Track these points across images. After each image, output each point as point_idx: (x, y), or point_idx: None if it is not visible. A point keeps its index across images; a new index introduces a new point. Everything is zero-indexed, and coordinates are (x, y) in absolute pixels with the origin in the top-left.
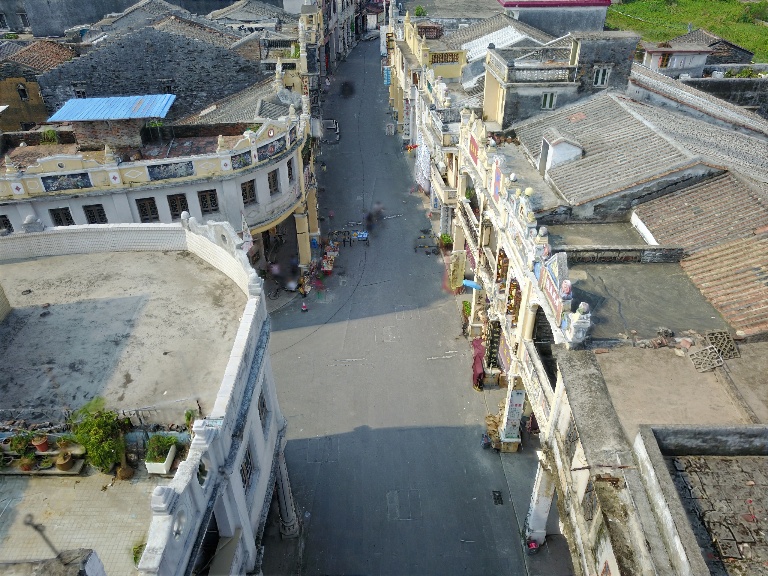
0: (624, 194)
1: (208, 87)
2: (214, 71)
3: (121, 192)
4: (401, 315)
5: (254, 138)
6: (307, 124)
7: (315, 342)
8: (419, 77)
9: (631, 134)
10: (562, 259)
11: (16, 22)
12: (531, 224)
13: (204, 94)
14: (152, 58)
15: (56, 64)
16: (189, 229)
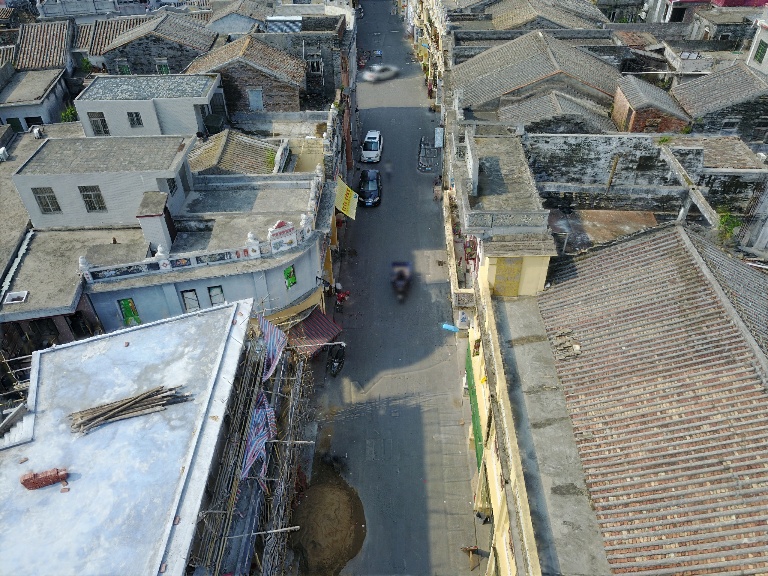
0: (481, 3)
1: None
2: None
3: None
4: (398, 80)
5: None
6: None
7: (359, 87)
8: None
9: None
10: (446, 10)
11: None
12: (441, 7)
13: None
14: None
15: None
16: (327, 5)
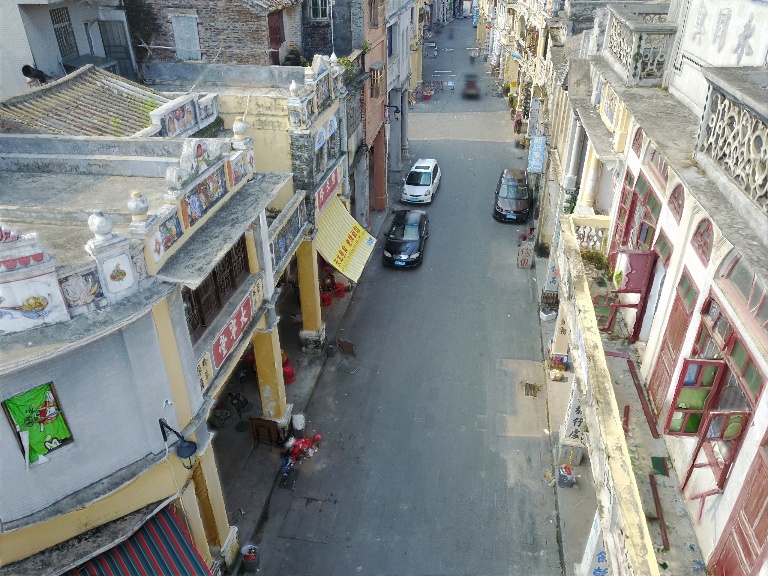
0: None
1: None
2: None
3: None
4: (473, 113)
5: None
6: None
7: (418, 117)
8: None
9: None
10: None
11: None
12: None
13: None
14: None
15: None
16: None
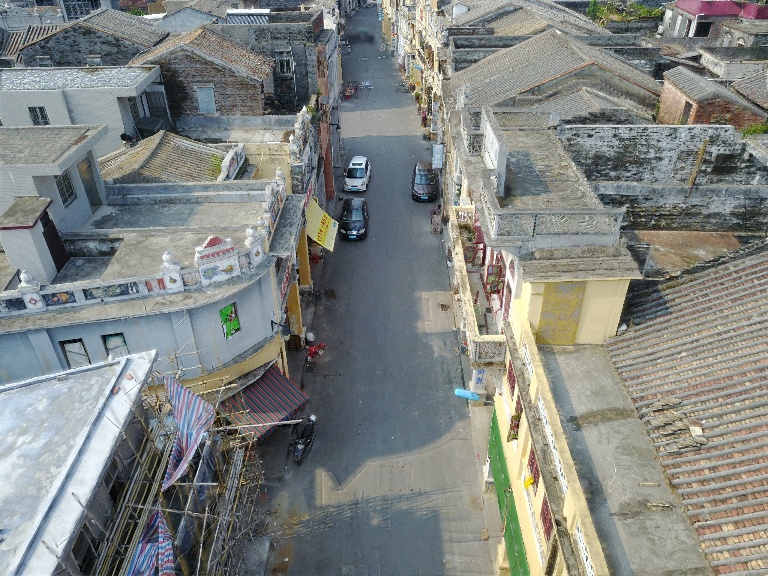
0: (481, 19)
1: (279, 4)
2: None
3: None
4: (388, 110)
5: (317, 7)
6: (338, 15)
7: (344, 116)
8: (399, 2)
9: (490, 0)
10: (442, 20)
11: None
12: (436, 21)
13: None
14: None
15: None
16: None
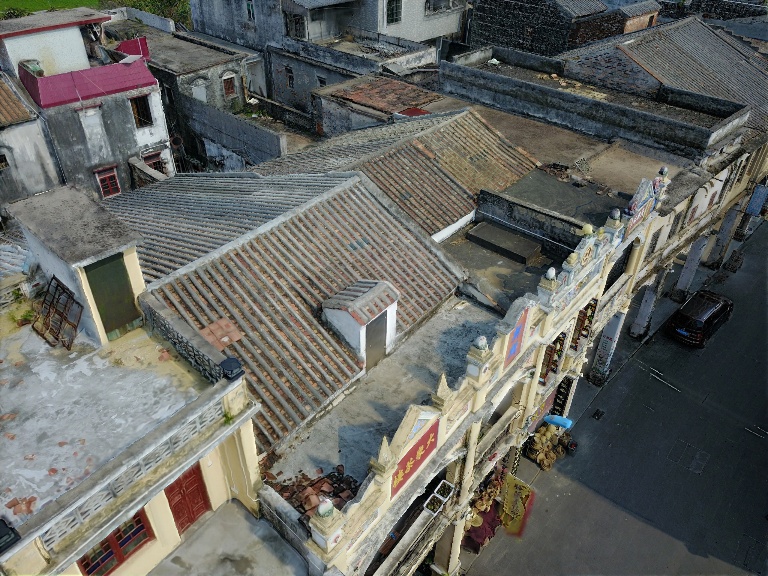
0: None
1: None
2: None
3: None
4: None
5: None
6: None
7: None
8: None
9: None
10: None
11: None
12: None
13: None
14: None
15: None
16: None
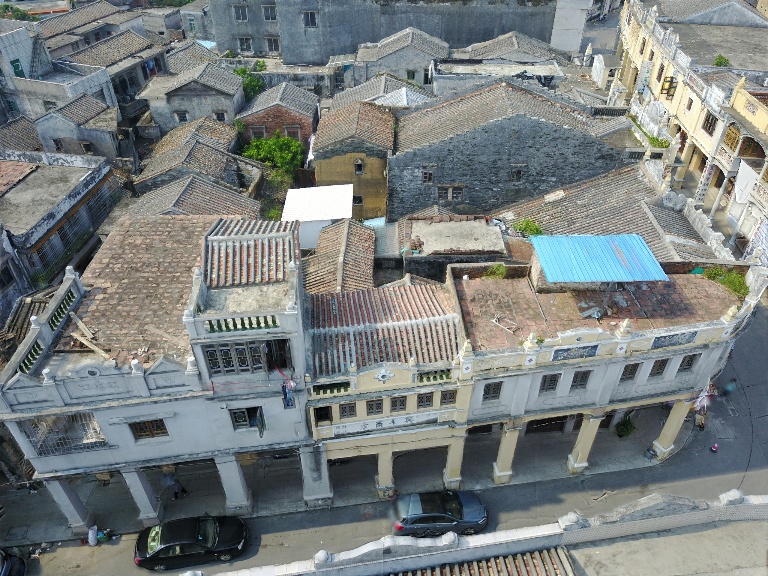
0: None
1: (560, 173)
2: (572, 158)
3: (622, 361)
4: None
5: None
6: None
7: None
8: None
9: None
10: None
11: (261, 46)
12: None
13: (553, 179)
14: (513, 144)
15: (390, 136)
16: None
